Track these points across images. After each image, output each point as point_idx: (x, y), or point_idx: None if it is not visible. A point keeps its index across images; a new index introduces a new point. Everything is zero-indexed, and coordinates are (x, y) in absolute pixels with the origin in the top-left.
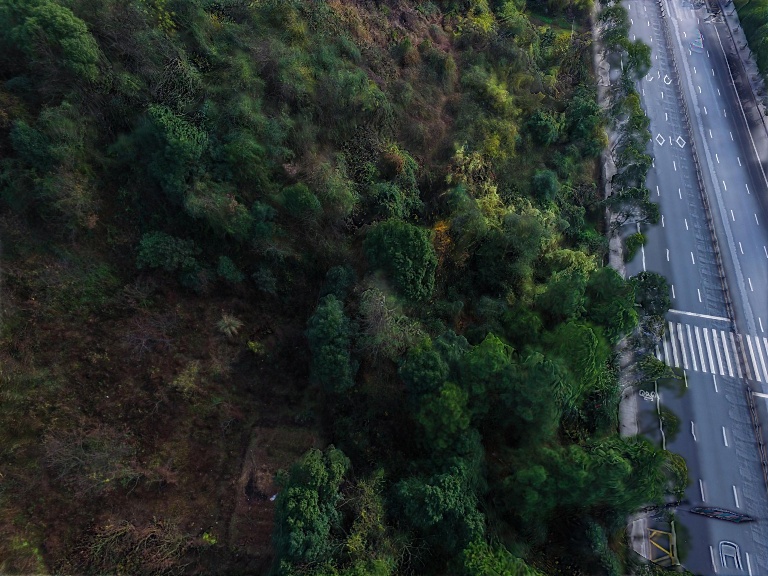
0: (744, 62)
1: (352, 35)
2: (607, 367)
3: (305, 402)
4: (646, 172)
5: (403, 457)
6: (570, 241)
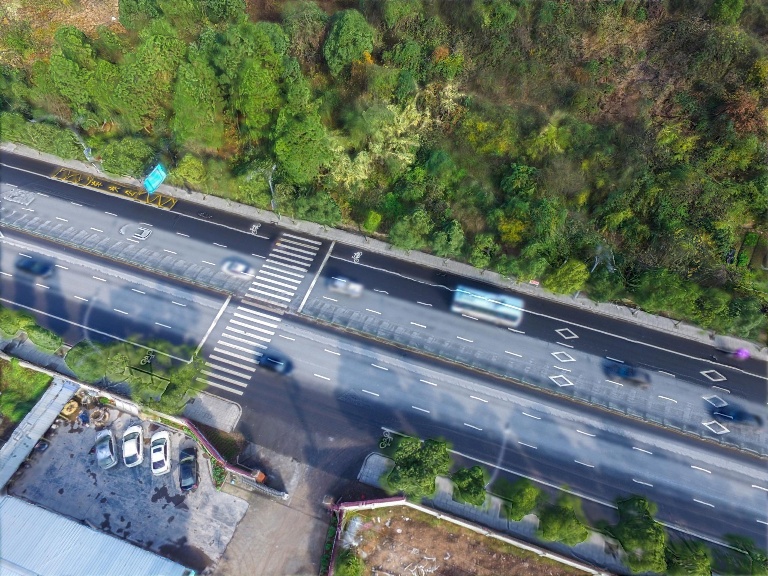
0: None
1: (585, 30)
2: None
3: None
4: (450, 236)
5: None
6: None
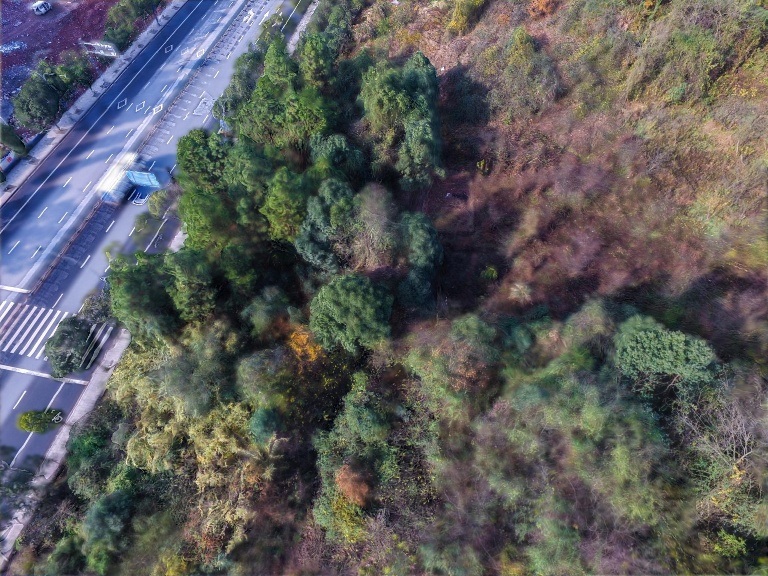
0: None
1: None
2: None
3: None
4: None
5: (358, 184)
6: None
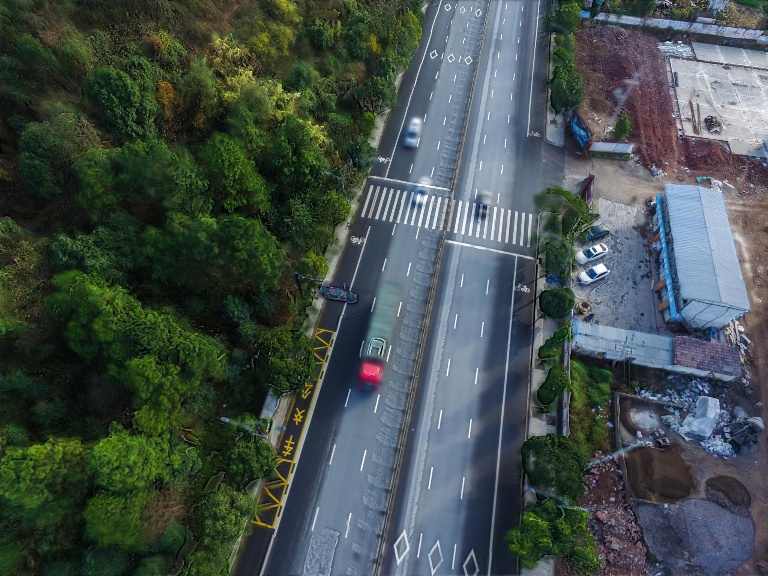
0: (554, 1)
1: None
2: (299, 202)
3: (38, 217)
4: (393, 67)
5: None
6: (321, 122)
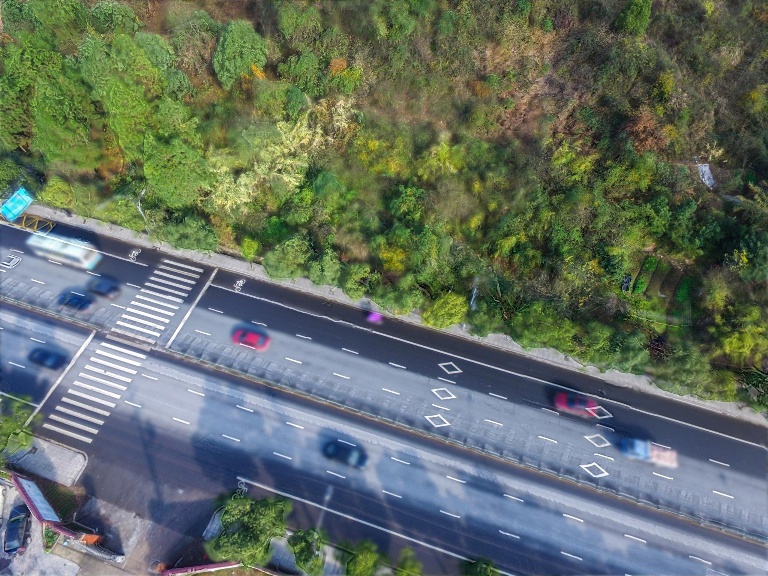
0: None
1: (490, 41)
2: None
3: None
4: (323, 267)
5: None
6: None
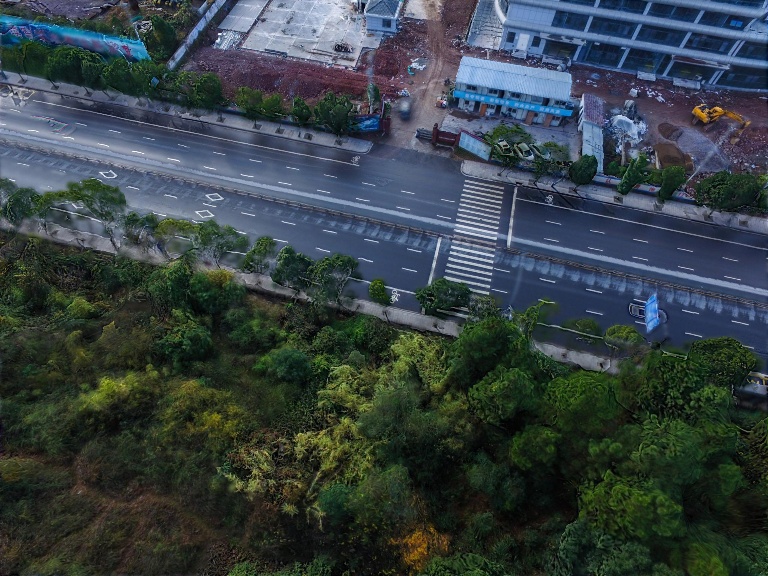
0: (111, 102)
1: None
2: None
3: None
4: None
5: None
6: (361, 353)
